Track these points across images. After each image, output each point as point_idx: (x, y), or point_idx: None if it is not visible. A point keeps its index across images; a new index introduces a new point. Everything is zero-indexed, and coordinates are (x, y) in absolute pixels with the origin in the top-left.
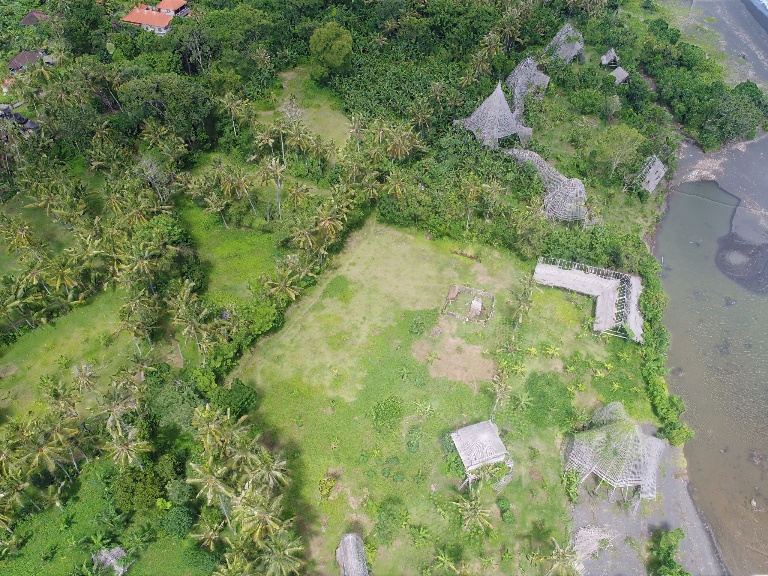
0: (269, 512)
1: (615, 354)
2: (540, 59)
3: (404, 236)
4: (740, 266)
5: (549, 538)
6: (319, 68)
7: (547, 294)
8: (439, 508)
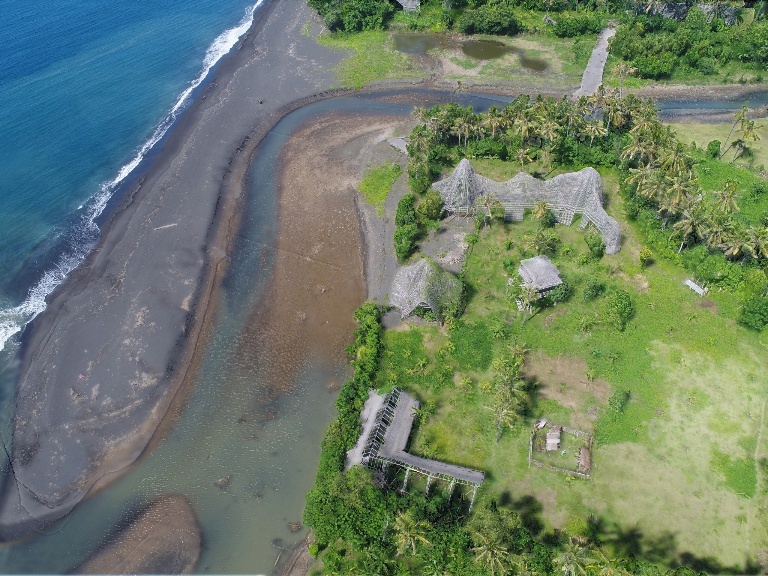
0: (677, 178)
1: None
2: None
3: None
4: (170, 548)
5: (479, 259)
6: None
7: None
8: (558, 263)
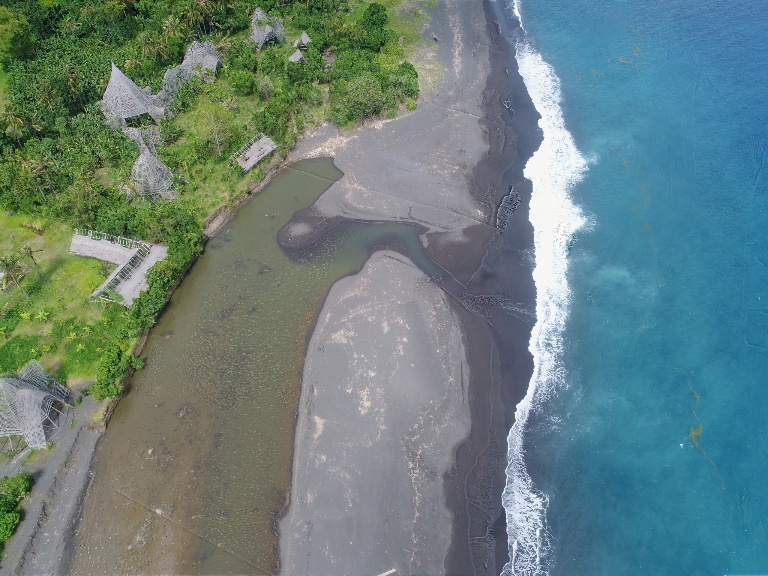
0: None
1: None
2: (221, 42)
3: None
4: (297, 237)
5: None
6: None
7: (84, 264)
8: None
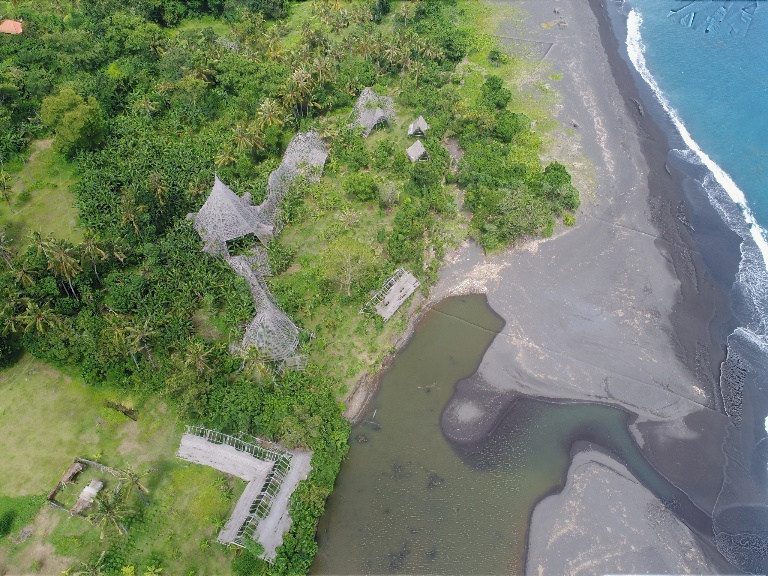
0: None
1: (240, 574)
2: (326, 131)
3: (58, 379)
4: (467, 425)
5: None
6: (57, 142)
7: (196, 472)
8: None
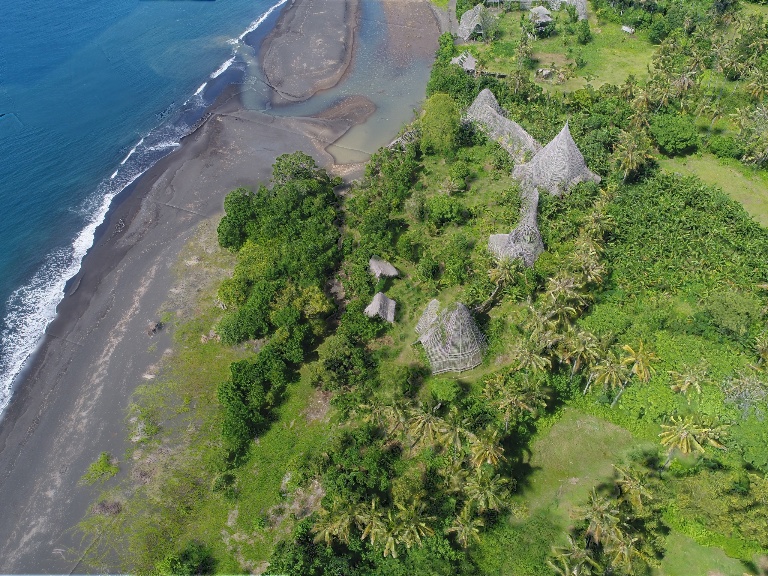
0: None
1: None
2: None
3: None
4: (361, 107)
5: (506, 23)
6: None
7: None
8: None
